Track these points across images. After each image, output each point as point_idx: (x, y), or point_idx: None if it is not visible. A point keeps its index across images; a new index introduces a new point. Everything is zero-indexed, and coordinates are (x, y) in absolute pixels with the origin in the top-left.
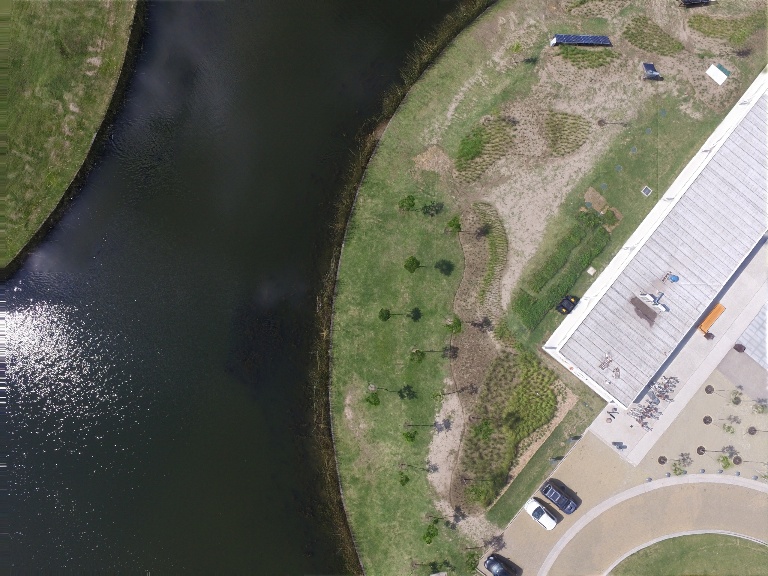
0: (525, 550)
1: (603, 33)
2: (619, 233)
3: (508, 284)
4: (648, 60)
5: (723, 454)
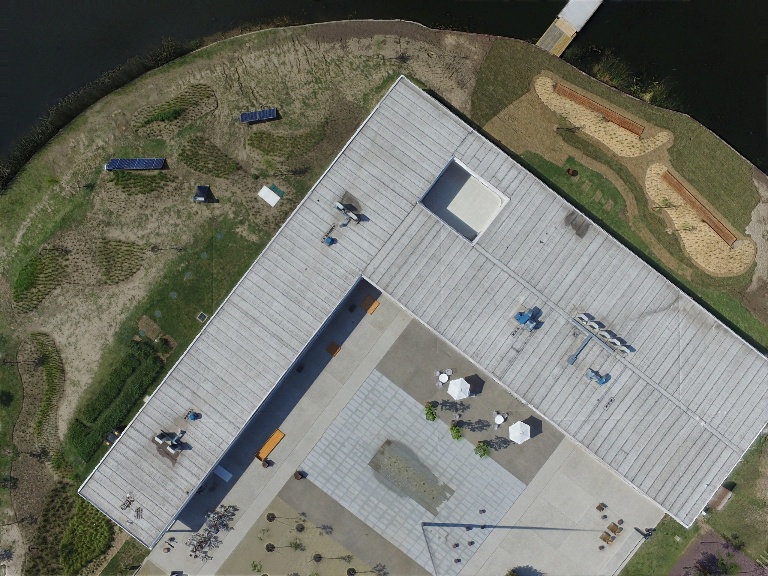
0: None
1: (162, 155)
2: (173, 361)
3: (65, 415)
4: (204, 182)
5: None
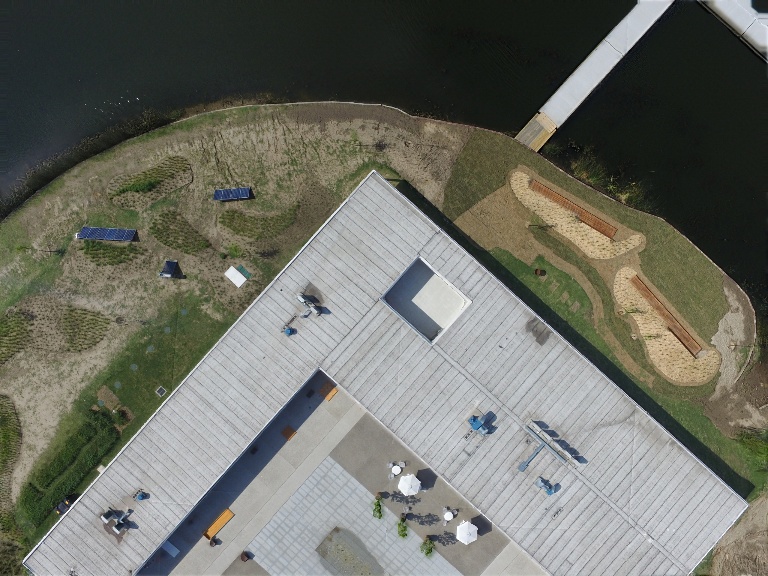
0: None
1: (133, 226)
2: (129, 433)
3: (19, 478)
4: (173, 257)
5: None
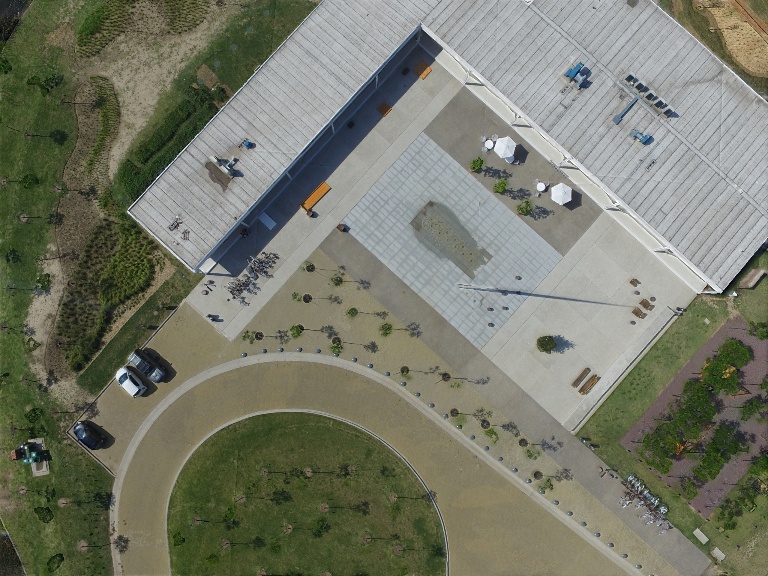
0: (118, 419)
1: None
2: None
3: (117, 155)
4: None
5: (322, 334)
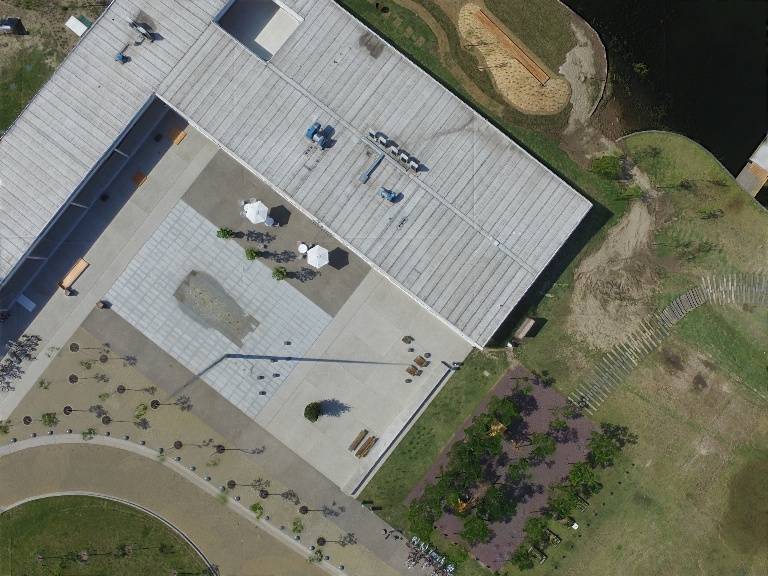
0: None
1: None
2: None
3: None
4: (15, 15)
5: (91, 414)
